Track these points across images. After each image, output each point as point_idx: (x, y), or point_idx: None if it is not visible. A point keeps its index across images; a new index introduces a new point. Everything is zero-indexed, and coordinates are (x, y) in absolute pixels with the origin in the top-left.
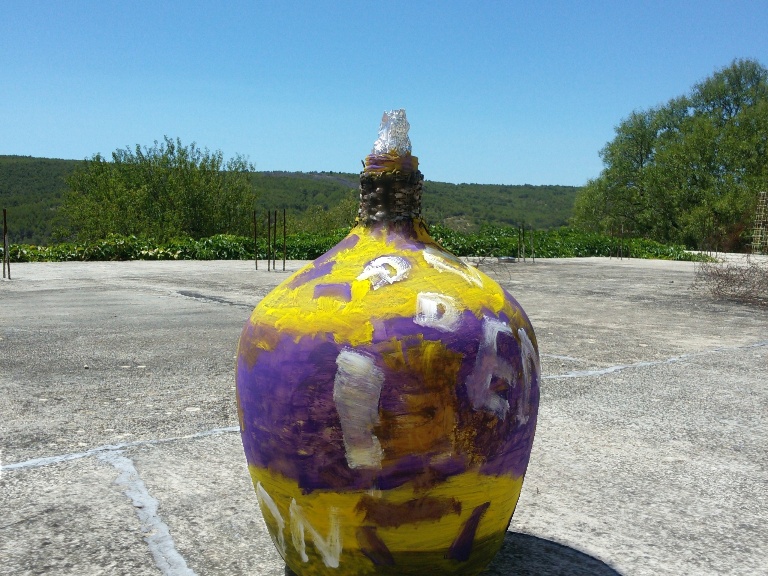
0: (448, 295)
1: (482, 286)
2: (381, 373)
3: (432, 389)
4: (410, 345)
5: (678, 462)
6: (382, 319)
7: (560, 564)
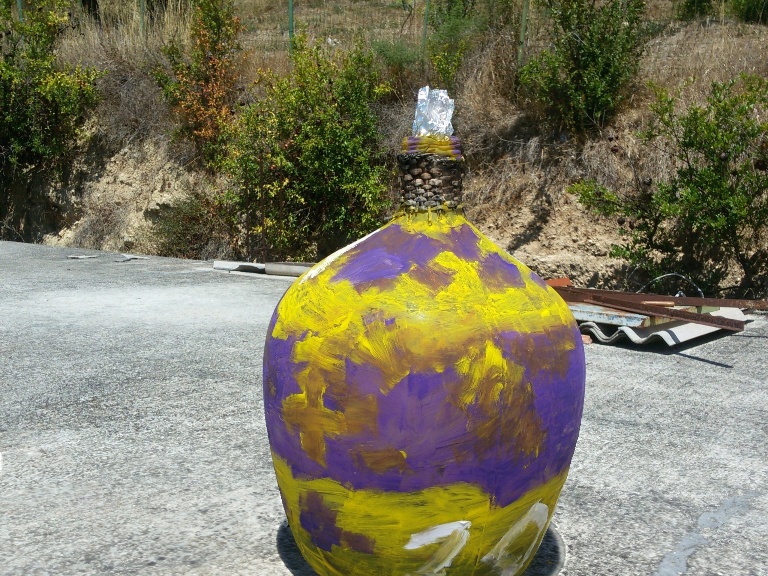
0: None
1: None
2: None
3: None
4: None
5: (46, 452)
6: None
7: None
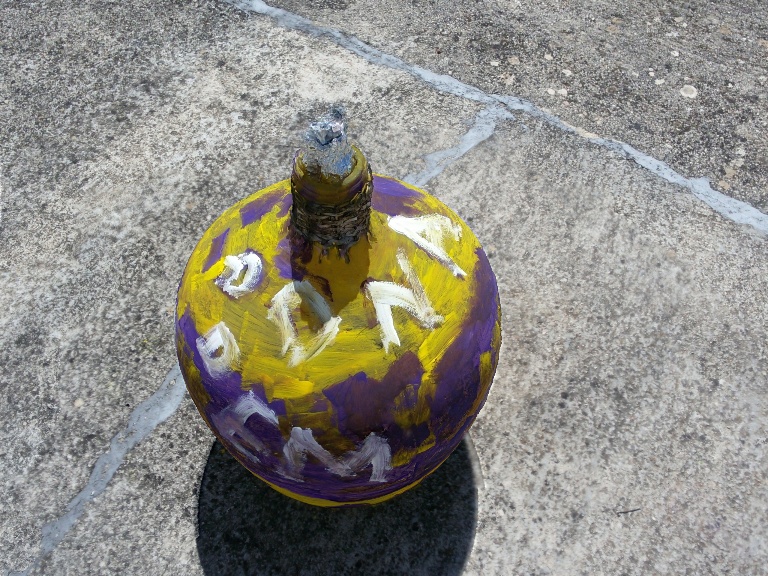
0: (239, 346)
1: (297, 364)
2: (176, 346)
3: (192, 393)
4: (186, 352)
5: None
6: (190, 313)
7: (416, 569)
